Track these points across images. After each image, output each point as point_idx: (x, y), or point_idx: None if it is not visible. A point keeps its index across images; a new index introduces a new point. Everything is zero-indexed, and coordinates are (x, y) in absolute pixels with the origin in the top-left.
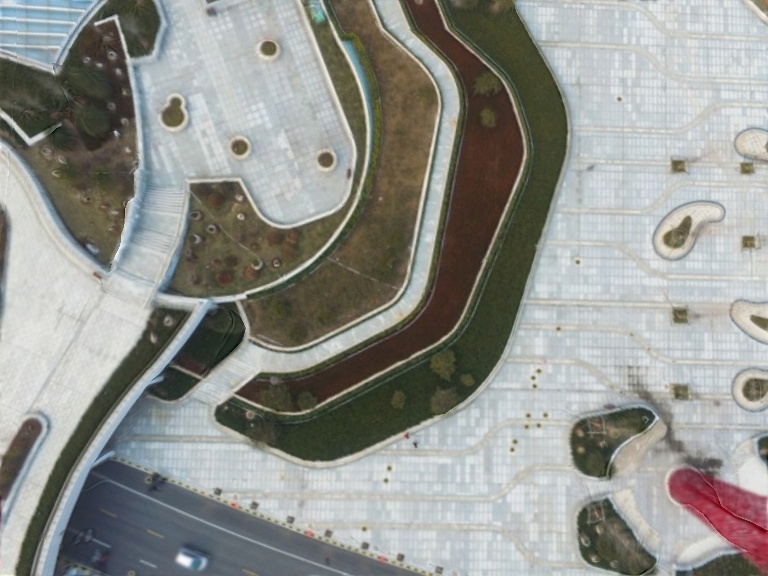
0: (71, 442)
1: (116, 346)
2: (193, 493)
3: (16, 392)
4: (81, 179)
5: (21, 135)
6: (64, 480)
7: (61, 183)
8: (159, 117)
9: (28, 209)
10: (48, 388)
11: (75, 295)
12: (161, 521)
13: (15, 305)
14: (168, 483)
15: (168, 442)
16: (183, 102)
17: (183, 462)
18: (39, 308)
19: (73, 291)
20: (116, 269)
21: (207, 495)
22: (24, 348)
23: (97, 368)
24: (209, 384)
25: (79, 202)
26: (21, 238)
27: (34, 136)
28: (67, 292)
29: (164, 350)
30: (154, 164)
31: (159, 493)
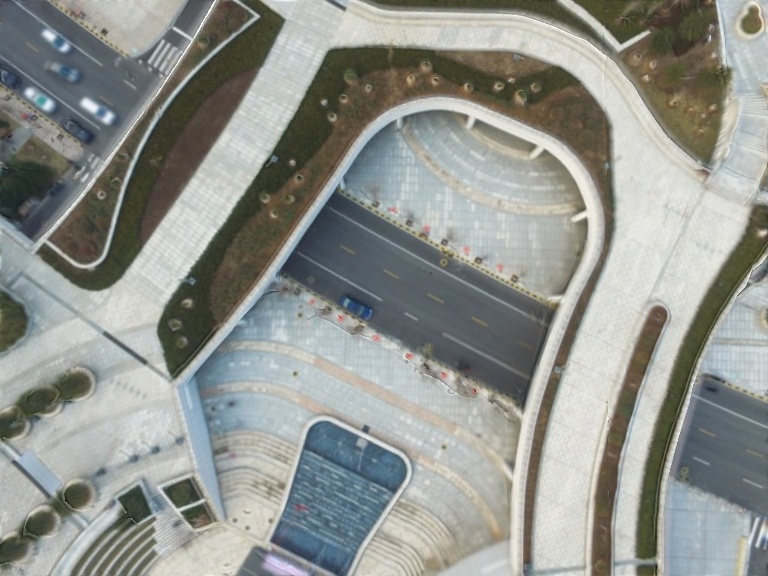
0: (692, 330)
1: (720, 241)
2: (742, 394)
3: (635, 282)
4: (670, 83)
5: (611, 42)
6: (692, 365)
7: (649, 87)
8: (738, 24)
9: (626, 111)
10: (663, 279)
11: (678, 192)
12: (712, 420)
13: (625, 200)
14: (719, 384)
15: (716, 344)
16: (759, 10)
17: (732, 364)
18: (647, 204)
19: (675, 188)
20: (720, 167)
21: (757, 396)
22: (637, 241)
23: (705, 261)
24: (760, 288)
25: (665, 106)
26: (623, 138)
27: (625, 42)
28: (670, 189)
29: (767, 245)
30: (730, 70)
31: (711, 393)
